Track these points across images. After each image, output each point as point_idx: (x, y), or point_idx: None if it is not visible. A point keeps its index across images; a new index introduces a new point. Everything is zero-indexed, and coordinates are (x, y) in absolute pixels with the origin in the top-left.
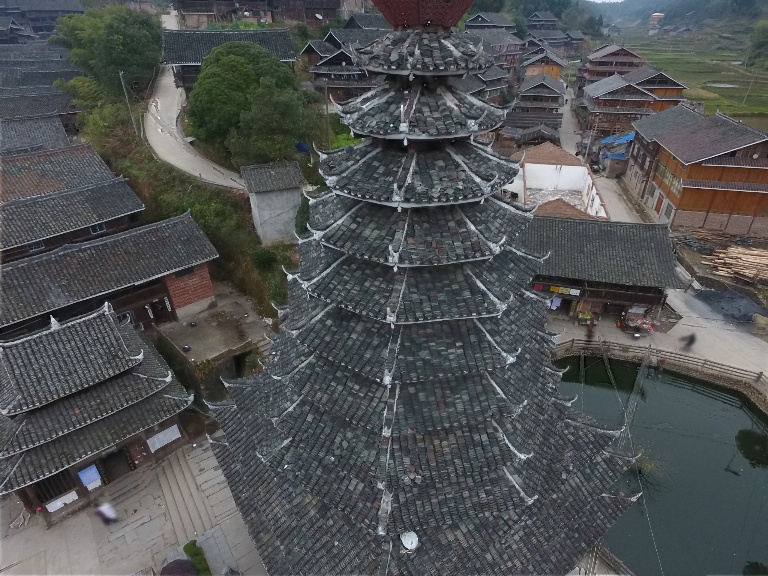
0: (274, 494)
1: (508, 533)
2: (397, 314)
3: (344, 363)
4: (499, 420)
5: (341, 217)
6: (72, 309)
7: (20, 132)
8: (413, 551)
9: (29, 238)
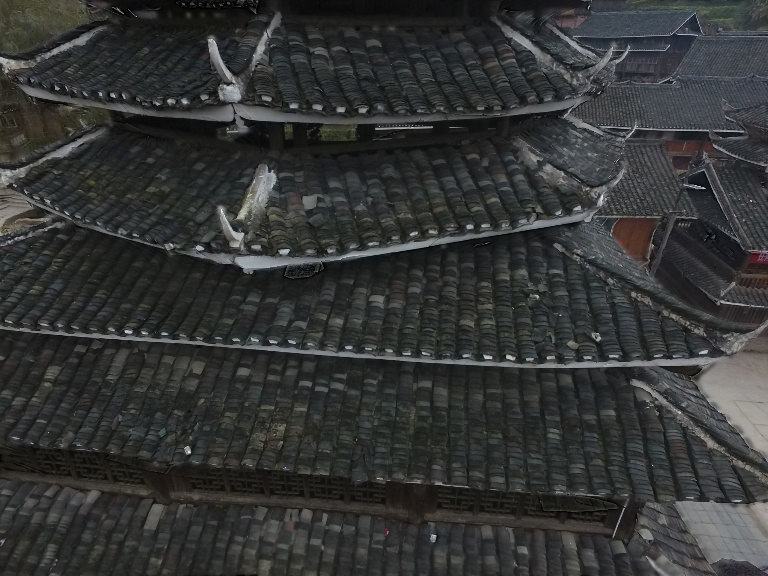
0: None
1: None
2: None
3: None
4: None
5: None
6: None
7: None
8: None
9: None
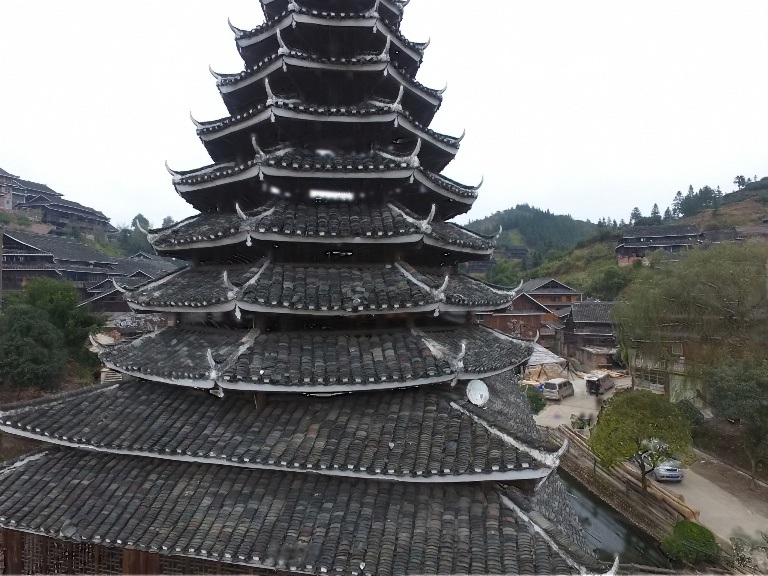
0: (195, 514)
1: None
2: None
3: (351, 166)
4: None
5: (298, 51)
6: None
7: None
8: (487, 407)
9: None
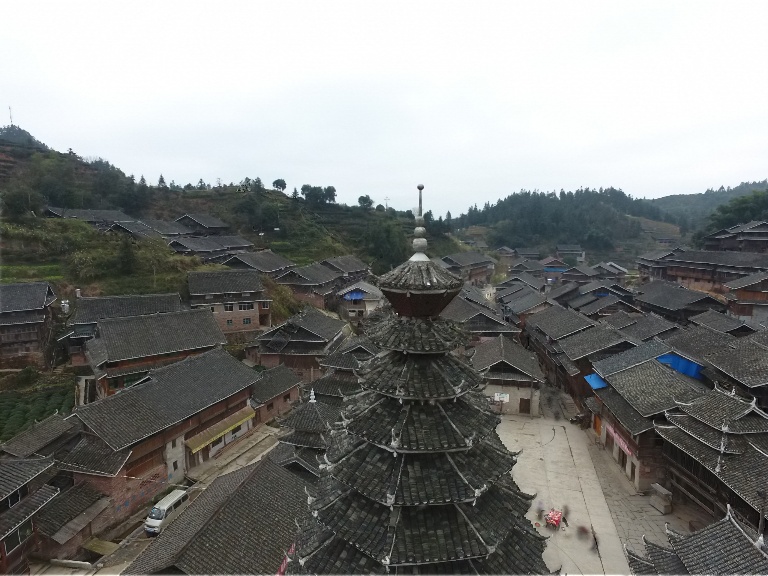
0: None
1: None
2: None
3: None
4: None
5: None
6: None
7: None
8: None
9: None
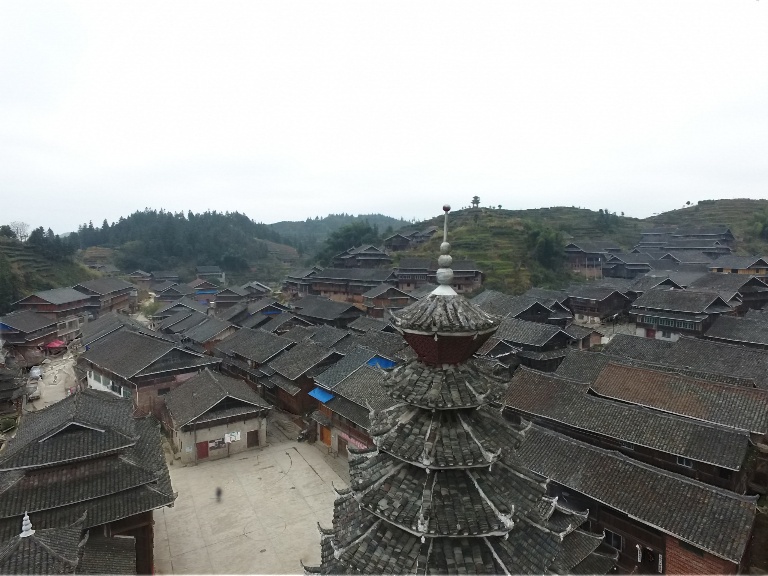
0: None
1: None
2: (326, 538)
3: None
4: None
5: None
6: (578, 496)
7: (762, 364)
8: None
9: (621, 436)
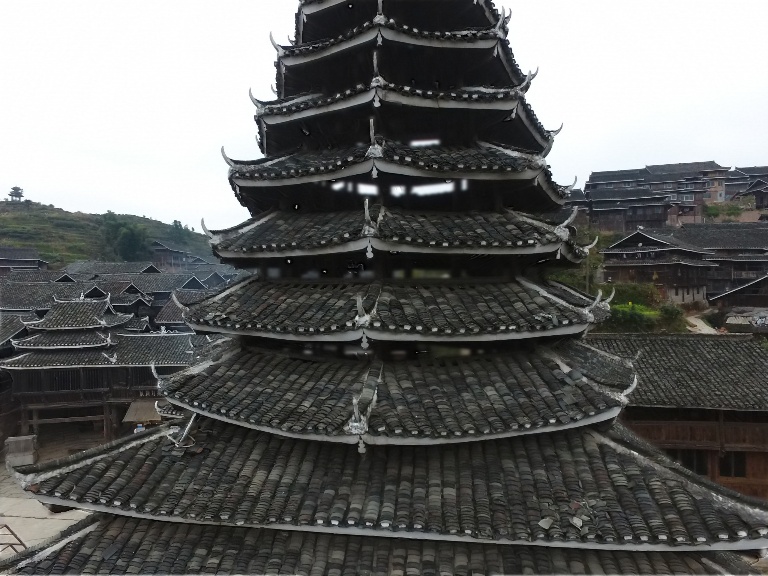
0: None
1: (370, 575)
2: None
3: None
4: (374, 287)
5: None
6: None
7: None
8: (182, 447)
9: None
